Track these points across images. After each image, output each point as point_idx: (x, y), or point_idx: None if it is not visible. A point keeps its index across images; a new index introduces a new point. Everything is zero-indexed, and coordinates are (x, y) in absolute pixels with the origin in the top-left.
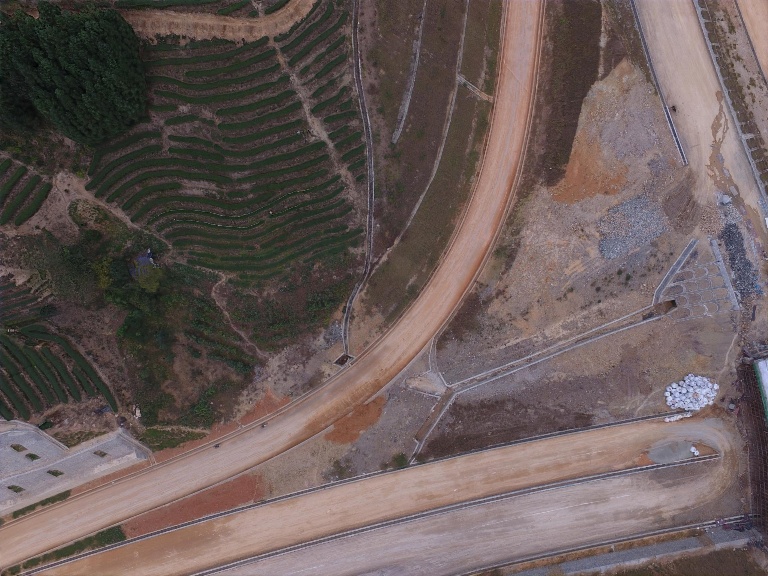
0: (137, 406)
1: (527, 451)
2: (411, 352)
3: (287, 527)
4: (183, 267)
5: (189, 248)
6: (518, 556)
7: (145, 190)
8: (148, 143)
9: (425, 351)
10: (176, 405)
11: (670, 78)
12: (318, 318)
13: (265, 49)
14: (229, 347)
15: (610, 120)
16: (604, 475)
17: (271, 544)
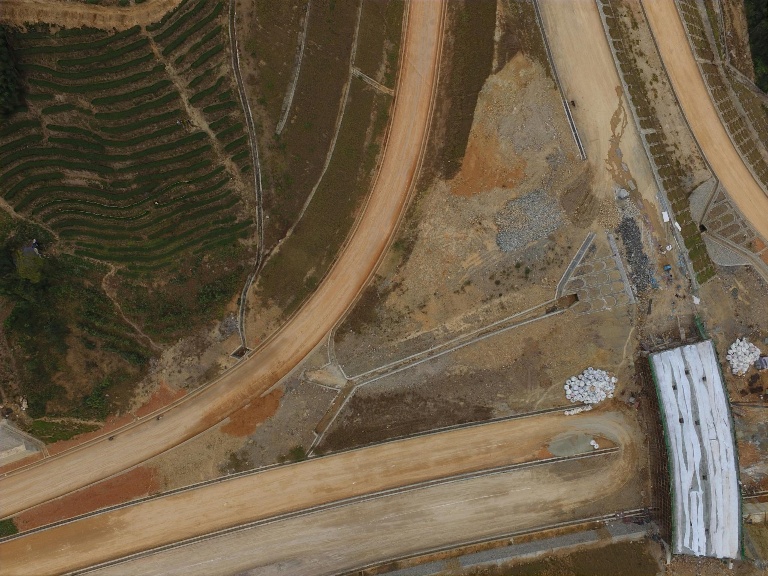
0: (24, 397)
1: (427, 444)
2: (309, 345)
3: (183, 520)
4: (71, 258)
5: (76, 239)
6: (417, 549)
7: (27, 180)
8: (29, 132)
9: (323, 344)
10: (67, 397)
11: (570, 73)
12: (210, 310)
13: (138, 38)
14: (123, 339)
15: (508, 114)
16: (504, 468)
17: (167, 537)
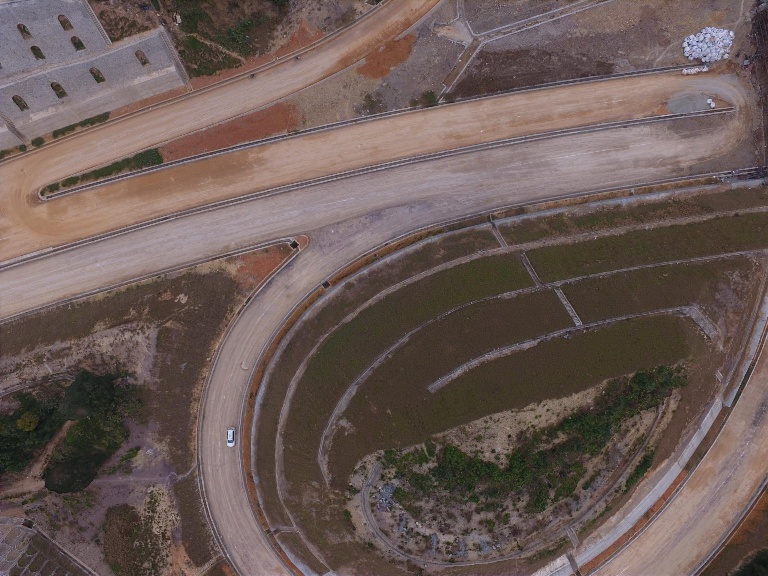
0: (177, 13)
1: (551, 97)
2: None
3: (319, 160)
4: None
5: None
6: (542, 197)
7: None
8: None
9: None
10: (214, 26)
11: None
12: None
13: None
14: None
15: None
16: (624, 122)
17: (303, 175)
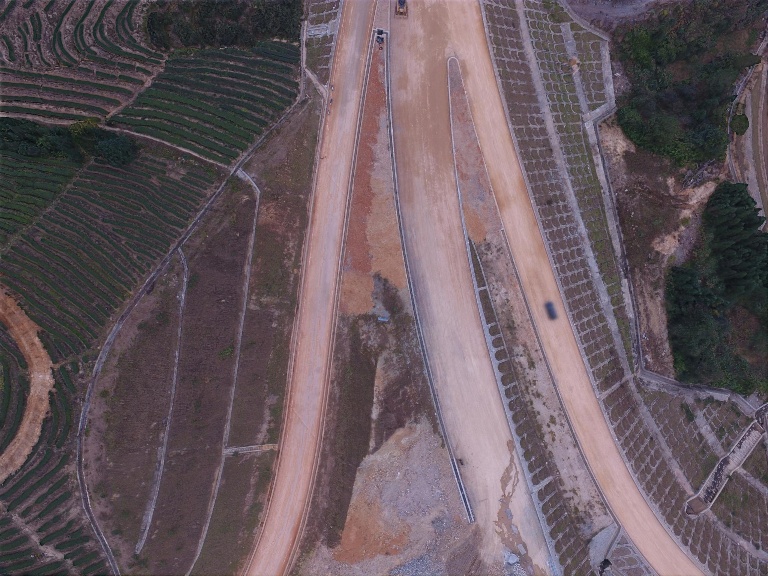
0: None
1: None
2: None
3: None
4: None
5: None
6: None
7: None
8: None
9: None
10: None
11: (459, 427)
12: None
13: None
14: None
15: (391, 480)
16: None
17: None
